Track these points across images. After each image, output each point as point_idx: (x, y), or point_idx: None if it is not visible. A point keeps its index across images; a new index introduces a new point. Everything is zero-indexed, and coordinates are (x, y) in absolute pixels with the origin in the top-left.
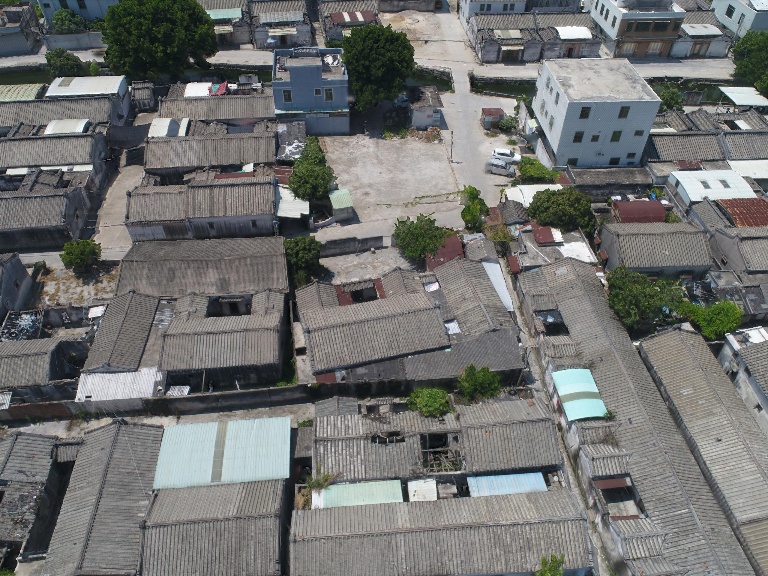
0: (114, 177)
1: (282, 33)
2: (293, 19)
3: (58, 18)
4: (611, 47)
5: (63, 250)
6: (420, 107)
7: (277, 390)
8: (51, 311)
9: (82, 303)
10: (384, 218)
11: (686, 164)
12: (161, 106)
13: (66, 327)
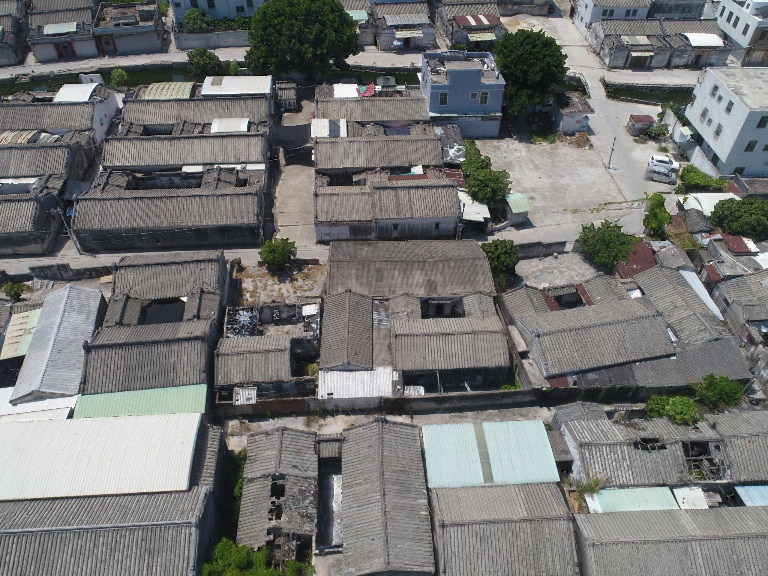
0: (278, 176)
1: (409, 35)
2: (419, 22)
3: (190, 17)
4: (739, 55)
5: (250, 247)
6: (571, 112)
7: (511, 393)
8: (265, 308)
9: None
10: (557, 223)
11: None
12: (317, 107)
13: (275, 324)
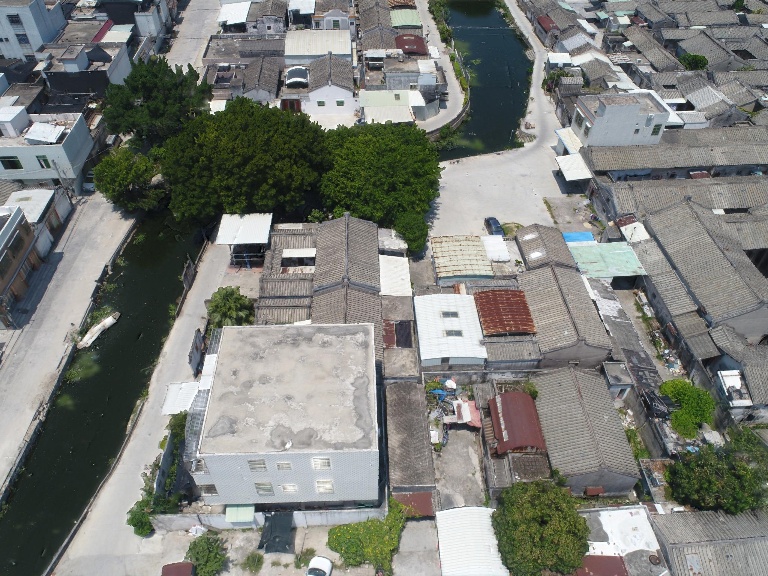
0: None
1: None
2: None
3: None
4: None
5: None
6: None
7: None
8: None
9: None
10: None
11: (389, 336)
12: None
13: None
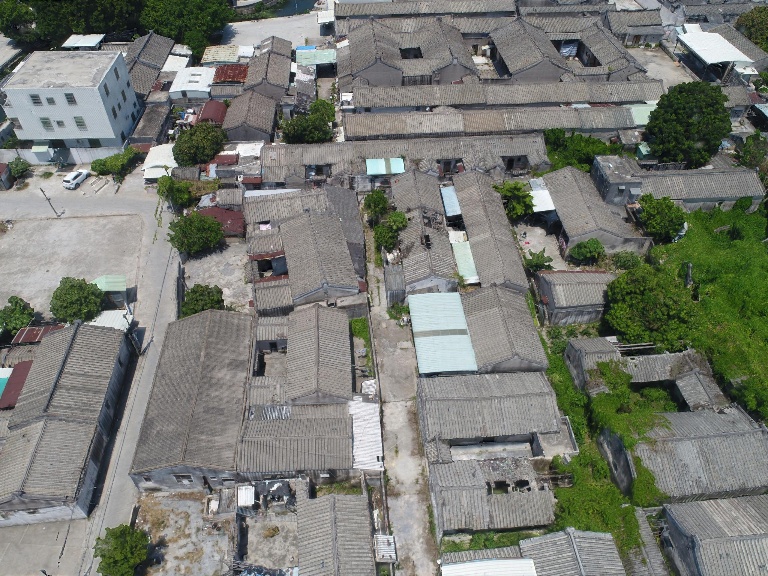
0: None
1: None
2: None
3: None
4: None
5: None
6: None
7: None
8: None
9: (201, 550)
10: (136, 269)
11: (157, 87)
12: None
13: (245, 554)
